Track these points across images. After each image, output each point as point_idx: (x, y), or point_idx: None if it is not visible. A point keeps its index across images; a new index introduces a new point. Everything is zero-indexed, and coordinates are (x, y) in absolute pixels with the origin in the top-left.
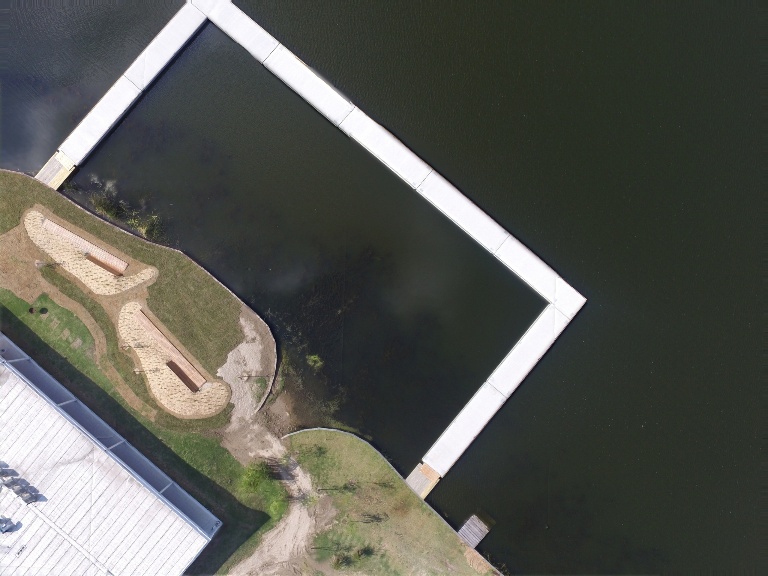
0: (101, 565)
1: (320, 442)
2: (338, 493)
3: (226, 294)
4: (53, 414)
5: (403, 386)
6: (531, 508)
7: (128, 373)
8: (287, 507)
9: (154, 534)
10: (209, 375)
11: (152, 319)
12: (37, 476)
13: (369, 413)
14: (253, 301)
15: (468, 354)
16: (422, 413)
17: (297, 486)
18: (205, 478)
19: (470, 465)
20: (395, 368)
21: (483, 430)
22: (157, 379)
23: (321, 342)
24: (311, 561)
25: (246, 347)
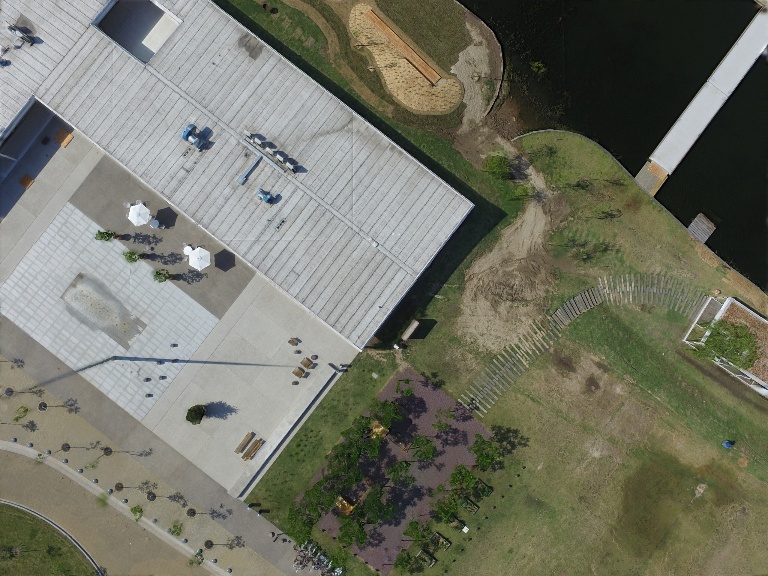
0: (365, 234)
1: (550, 142)
2: (571, 190)
3: (450, 1)
4: (310, 85)
5: (625, 91)
6: (754, 205)
7: (362, 71)
8: (522, 205)
9: (418, 201)
10: (443, 72)
11: (383, 19)
12: (296, 148)
13: (594, 117)
14: (476, 9)
15: (686, 59)
16: (645, 116)
17: (531, 184)
18: (446, 170)
19: (693, 166)
20: (617, 73)
21: (706, 129)
22: (394, 74)
23: (544, 49)
24: (548, 258)
25: (474, 49)
